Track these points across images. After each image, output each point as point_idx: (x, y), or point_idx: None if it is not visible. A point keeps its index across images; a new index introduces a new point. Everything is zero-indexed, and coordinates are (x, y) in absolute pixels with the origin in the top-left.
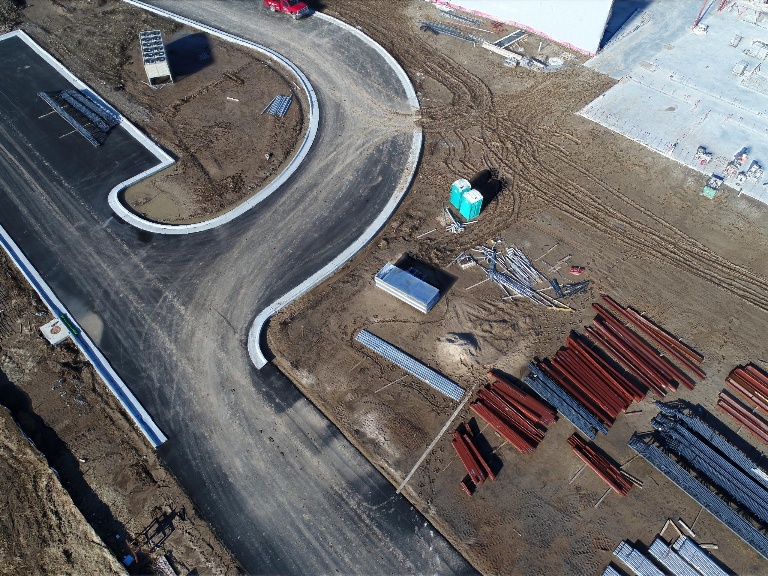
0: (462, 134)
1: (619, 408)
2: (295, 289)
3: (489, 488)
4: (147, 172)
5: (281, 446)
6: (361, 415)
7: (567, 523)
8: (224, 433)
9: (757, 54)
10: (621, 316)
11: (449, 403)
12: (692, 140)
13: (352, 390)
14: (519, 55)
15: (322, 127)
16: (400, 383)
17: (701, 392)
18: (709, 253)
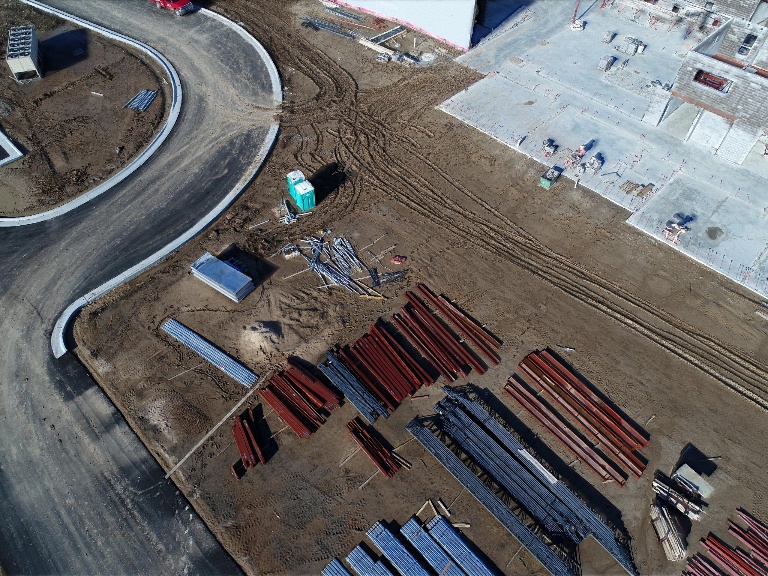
0: (319, 128)
1: (405, 393)
2: (113, 279)
3: (259, 472)
4: None
5: (61, 433)
6: (149, 402)
7: (328, 505)
8: (7, 421)
9: (626, 50)
10: (431, 304)
11: (239, 390)
12: (543, 133)
13: (146, 378)
14: (392, 51)
15: (180, 121)
16: (196, 371)
17: (491, 376)
18: (533, 242)
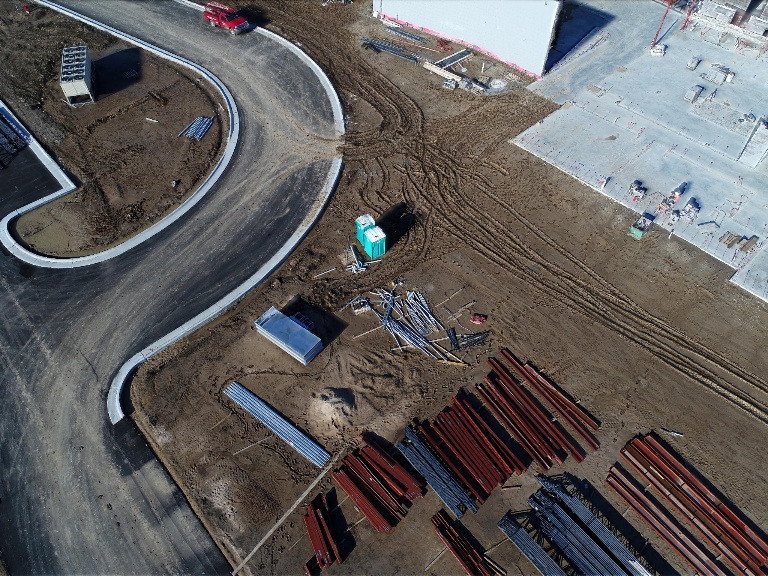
0: (384, 162)
1: (495, 482)
2: (171, 333)
3: (335, 573)
4: (45, 199)
5: (118, 515)
6: (212, 481)
7: None
8: (61, 497)
9: (714, 78)
10: (517, 373)
11: (310, 470)
12: (628, 173)
13: (209, 451)
14: (459, 76)
15: (238, 152)
16: (262, 445)
17: (591, 465)
18: (626, 302)
